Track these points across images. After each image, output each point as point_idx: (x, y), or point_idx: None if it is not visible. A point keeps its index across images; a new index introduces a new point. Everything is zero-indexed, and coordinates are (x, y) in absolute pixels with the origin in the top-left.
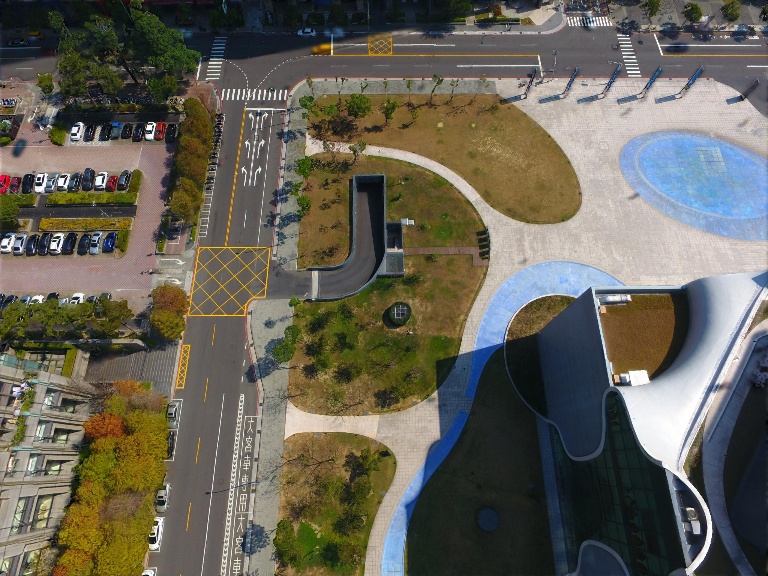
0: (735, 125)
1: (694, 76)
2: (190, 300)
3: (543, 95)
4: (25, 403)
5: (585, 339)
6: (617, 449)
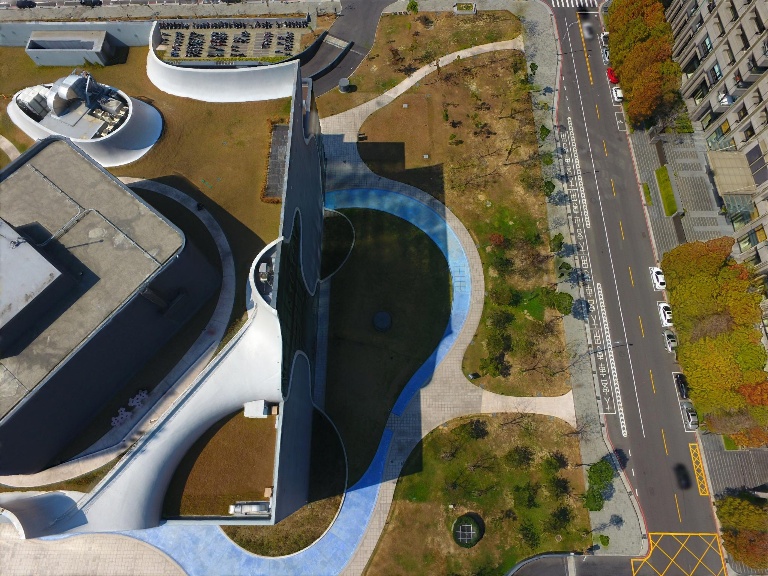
0: None
1: None
2: (723, 557)
3: None
4: None
5: (287, 465)
6: (289, 347)
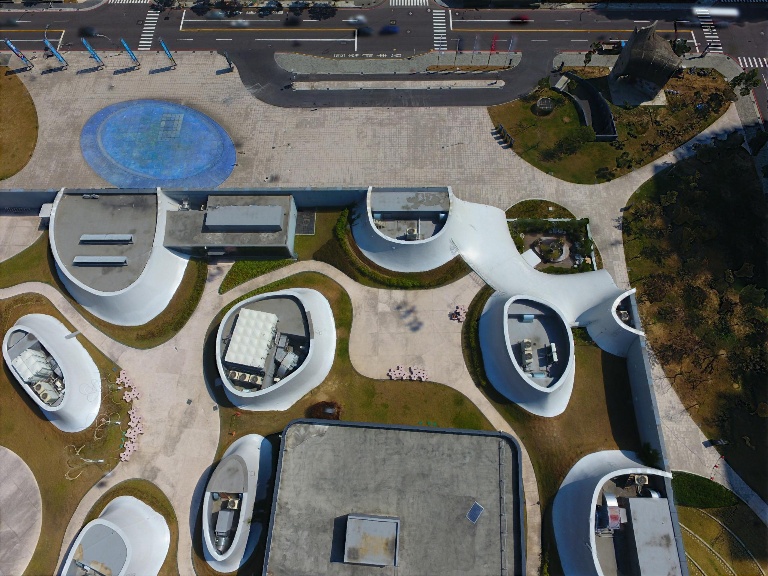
0: (211, 94)
1: (165, 47)
2: None
3: (48, 67)
4: None
5: None
6: None
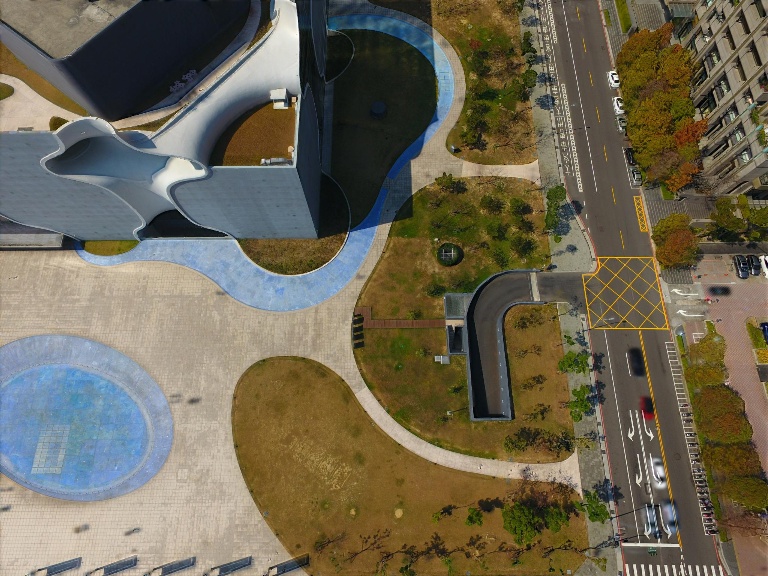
0: None
1: None
2: (657, 273)
3: (243, 575)
4: (764, 135)
5: None
6: None
